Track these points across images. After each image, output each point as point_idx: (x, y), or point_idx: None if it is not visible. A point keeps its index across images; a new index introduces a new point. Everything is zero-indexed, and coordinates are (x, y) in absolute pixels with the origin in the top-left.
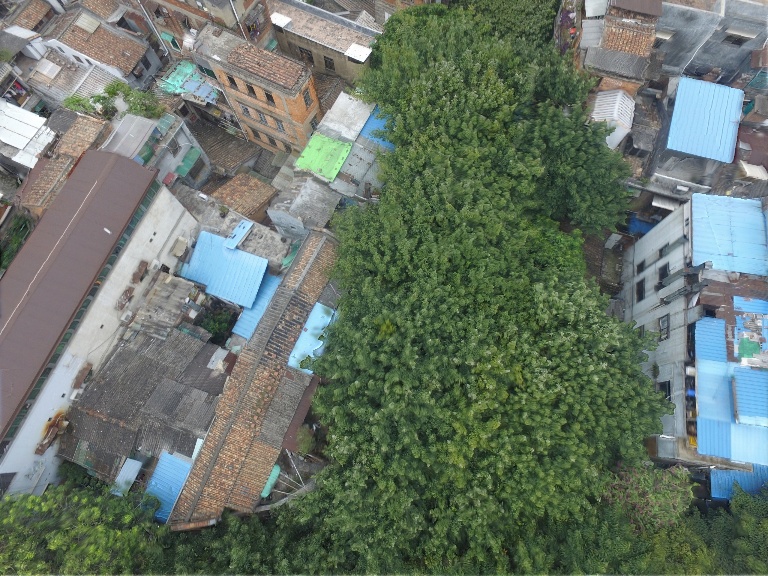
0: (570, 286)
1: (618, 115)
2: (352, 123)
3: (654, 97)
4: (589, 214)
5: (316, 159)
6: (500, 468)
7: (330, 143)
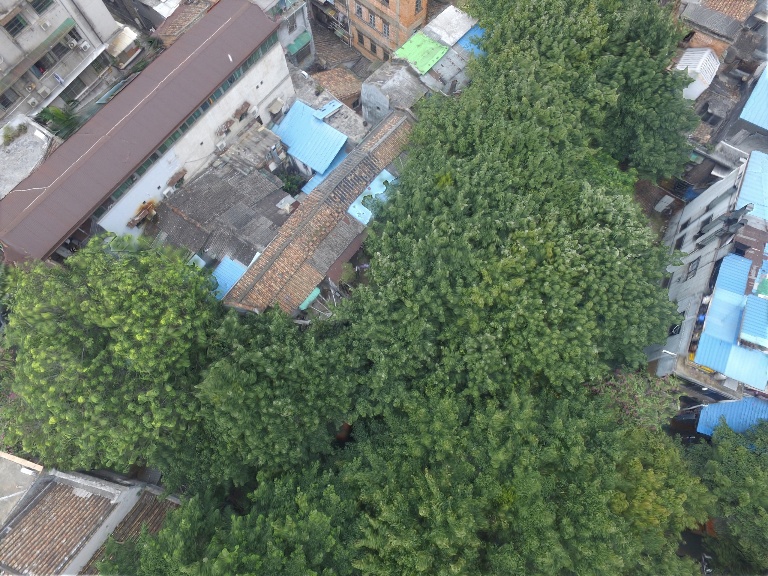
0: None
1: (700, 69)
2: (453, 31)
3: (740, 79)
4: (649, 156)
5: (414, 53)
6: (512, 322)
7: (430, 43)
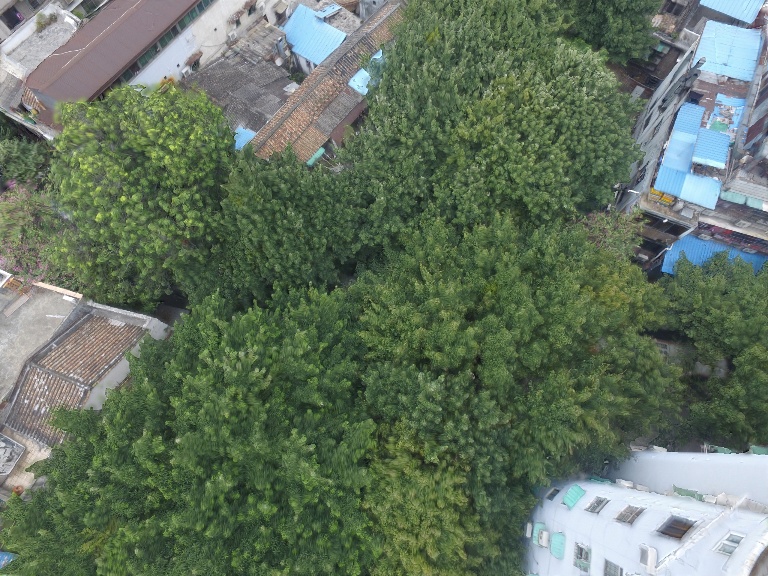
0: None
1: None
2: None
3: None
4: (618, 37)
5: None
6: (495, 156)
7: None
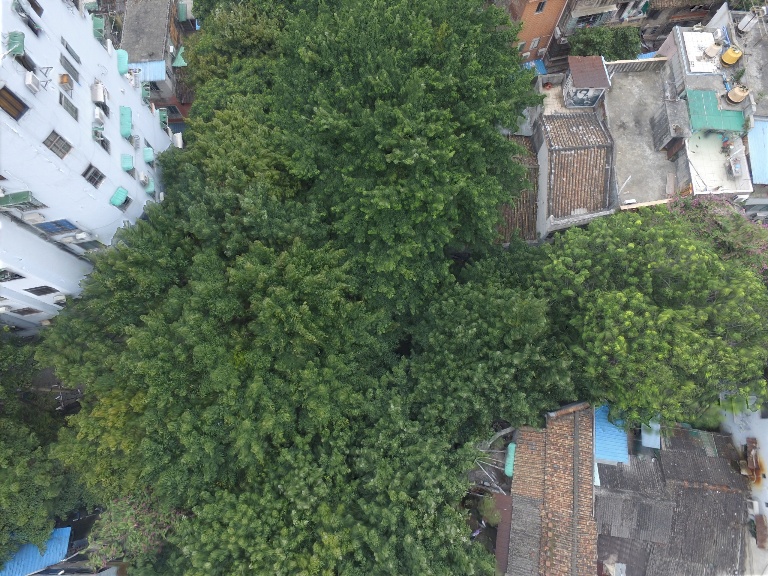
0: None
1: None
2: None
3: None
4: None
5: None
6: (284, 536)
7: None
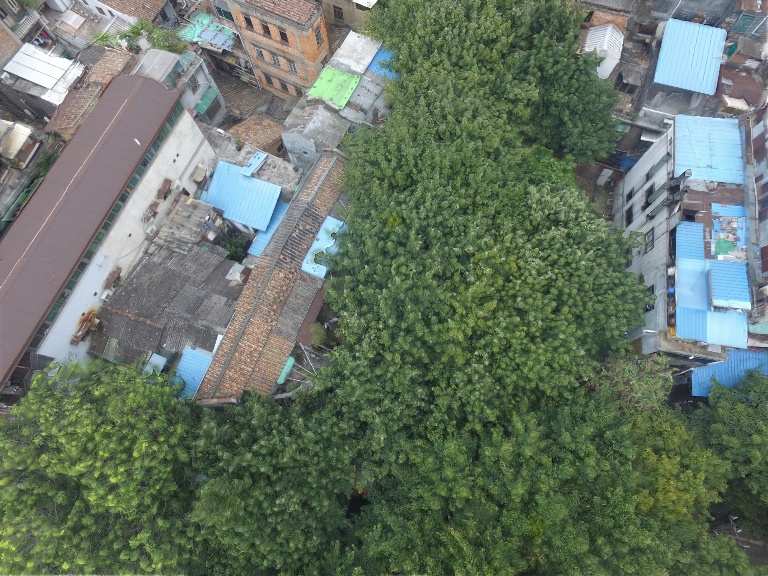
0: (561, 193)
1: (607, 46)
2: (361, 58)
3: (644, 42)
4: (581, 140)
5: (327, 89)
6: (496, 346)
7: (340, 75)
